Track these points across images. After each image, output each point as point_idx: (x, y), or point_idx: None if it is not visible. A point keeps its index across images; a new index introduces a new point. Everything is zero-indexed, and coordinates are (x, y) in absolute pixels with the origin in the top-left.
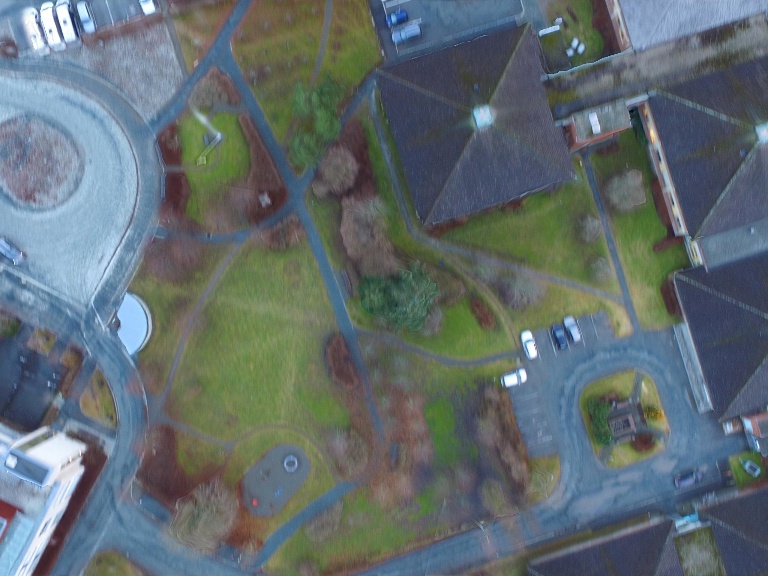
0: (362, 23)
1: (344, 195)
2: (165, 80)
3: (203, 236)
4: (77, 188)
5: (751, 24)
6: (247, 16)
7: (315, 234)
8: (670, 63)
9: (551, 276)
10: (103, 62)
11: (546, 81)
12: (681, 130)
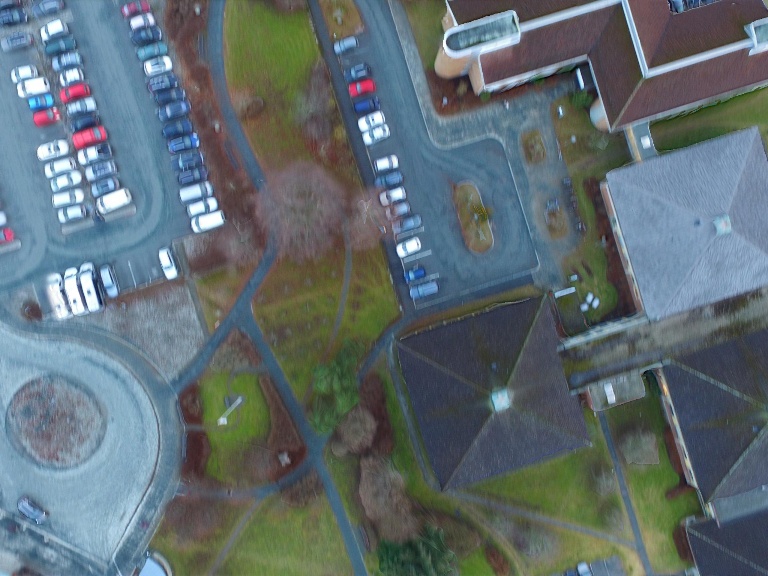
0: (381, 281)
1: (363, 455)
2: (187, 341)
3: (223, 493)
4: (99, 446)
5: (763, 294)
6: (268, 278)
7: (334, 490)
8: (684, 333)
9: (565, 523)
10: (126, 324)
11: (562, 351)
12: (695, 400)
